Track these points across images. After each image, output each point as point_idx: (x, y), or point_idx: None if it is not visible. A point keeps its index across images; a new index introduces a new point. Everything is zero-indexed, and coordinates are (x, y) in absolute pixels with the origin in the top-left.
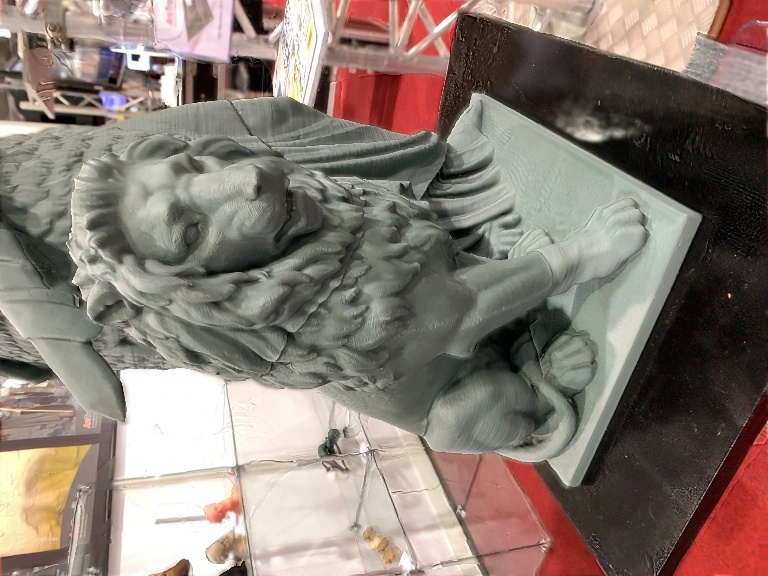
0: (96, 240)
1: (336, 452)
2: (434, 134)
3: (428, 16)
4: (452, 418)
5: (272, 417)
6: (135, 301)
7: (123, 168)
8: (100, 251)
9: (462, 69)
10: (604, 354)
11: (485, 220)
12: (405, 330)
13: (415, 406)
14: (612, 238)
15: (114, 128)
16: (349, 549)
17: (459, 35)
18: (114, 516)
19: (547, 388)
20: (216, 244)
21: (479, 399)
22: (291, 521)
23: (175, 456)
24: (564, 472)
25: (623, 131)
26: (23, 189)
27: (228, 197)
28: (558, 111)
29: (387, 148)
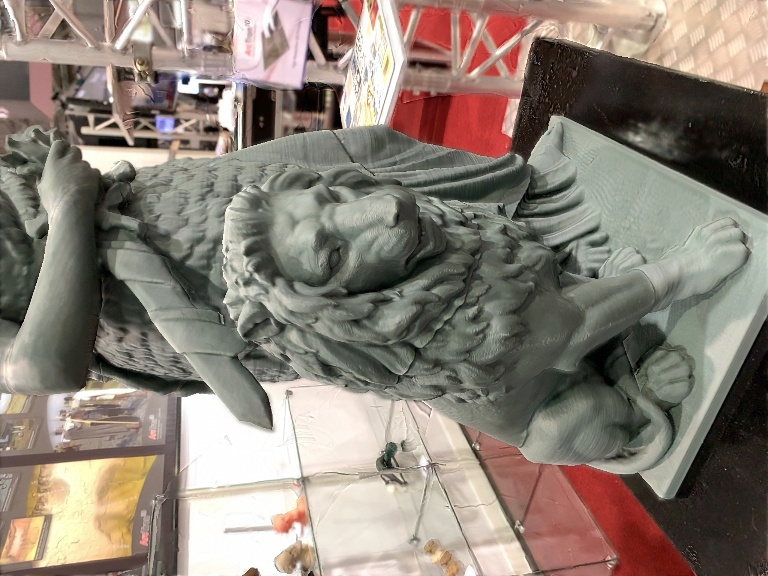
0: (253, 265)
1: (393, 465)
2: (518, 156)
3: (489, 38)
4: (554, 430)
5: (328, 430)
6: (284, 319)
7: (269, 199)
8: (256, 274)
9: (538, 92)
10: (702, 368)
11: (572, 238)
12: (520, 345)
13: (518, 418)
14: (713, 256)
15: (233, 159)
16: (408, 562)
17: (534, 59)
18: (181, 525)
19: (645, 401)
20: (355, 267)
21: (581, 412)
22: (350, 533)
23: (243, 467)
24: (658, 484)
25: (717, 152)
26: (166, 218)
27: (369, 224)
28: (645, 133)
29: (478, 171)
